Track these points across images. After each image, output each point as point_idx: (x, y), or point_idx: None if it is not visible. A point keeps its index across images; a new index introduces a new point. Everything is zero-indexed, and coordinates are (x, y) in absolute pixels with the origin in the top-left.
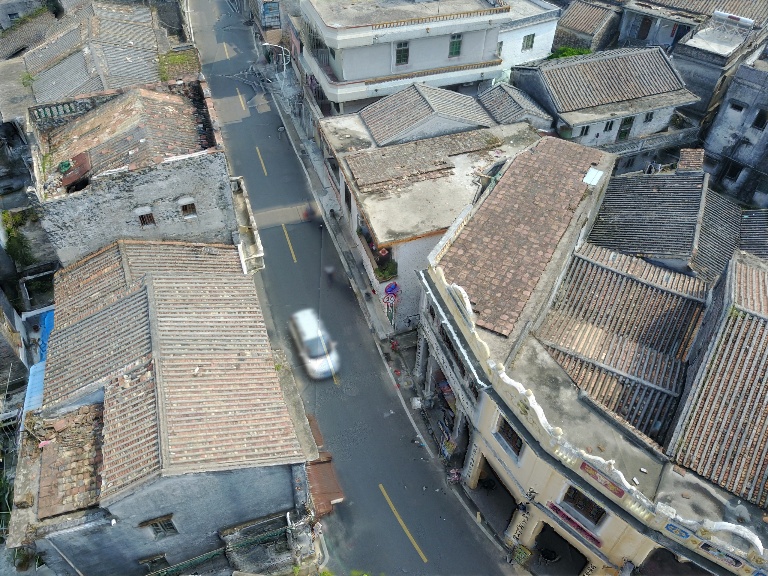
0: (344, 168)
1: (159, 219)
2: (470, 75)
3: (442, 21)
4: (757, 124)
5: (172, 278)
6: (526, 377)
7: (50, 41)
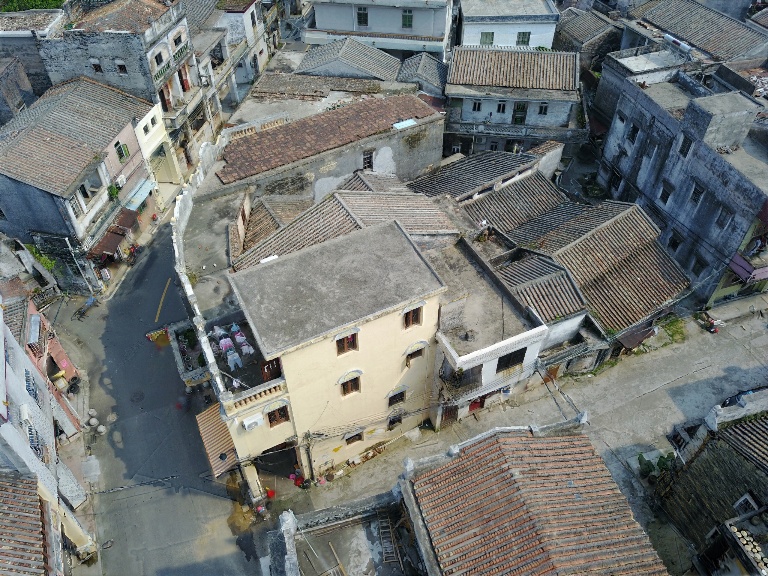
0: (258, 80)
1: (105, 70)
2: (414, 45)
3: None
4: (632, 137)
5: (82, 99)
6: (214, 207)
7: None
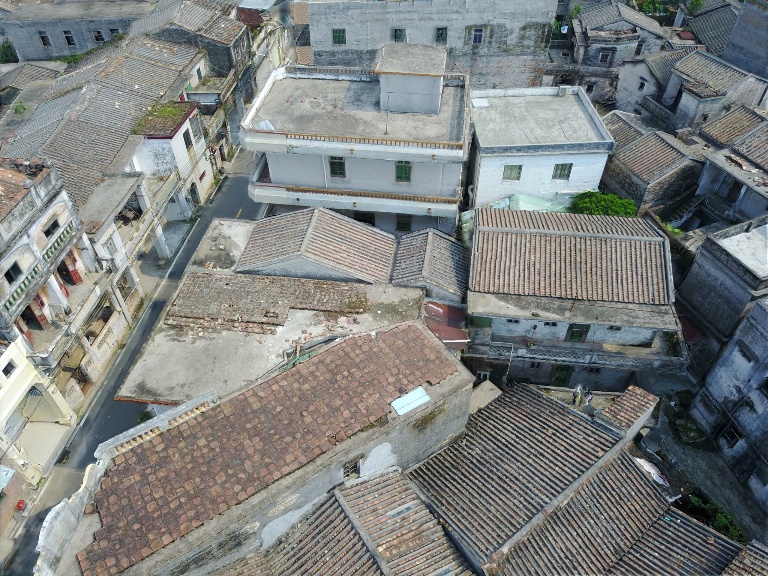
0: (178, 287)
1: None
2: (414, 207)
3: (372, 144)
4: (766, 389)
5: None
6: None
7: (80, 70)
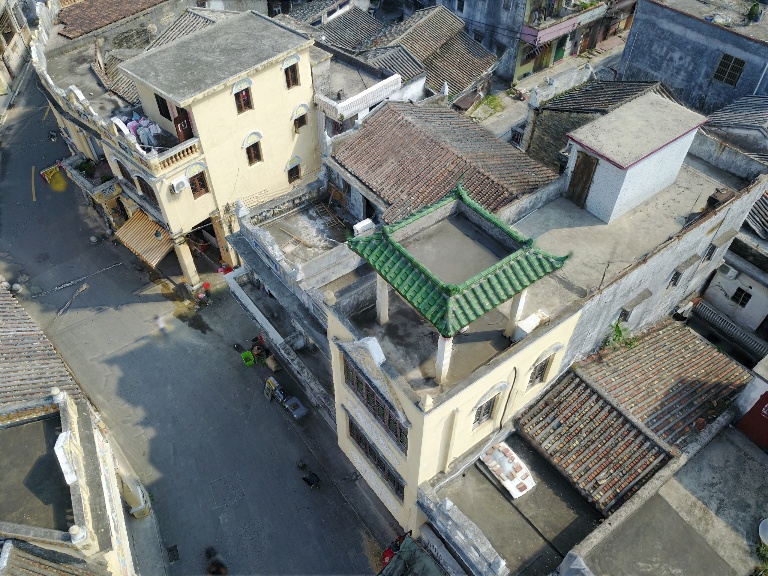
0: None
1: None
2: None
3: None
4: None
5: None
6: (69, 58)
7: None
